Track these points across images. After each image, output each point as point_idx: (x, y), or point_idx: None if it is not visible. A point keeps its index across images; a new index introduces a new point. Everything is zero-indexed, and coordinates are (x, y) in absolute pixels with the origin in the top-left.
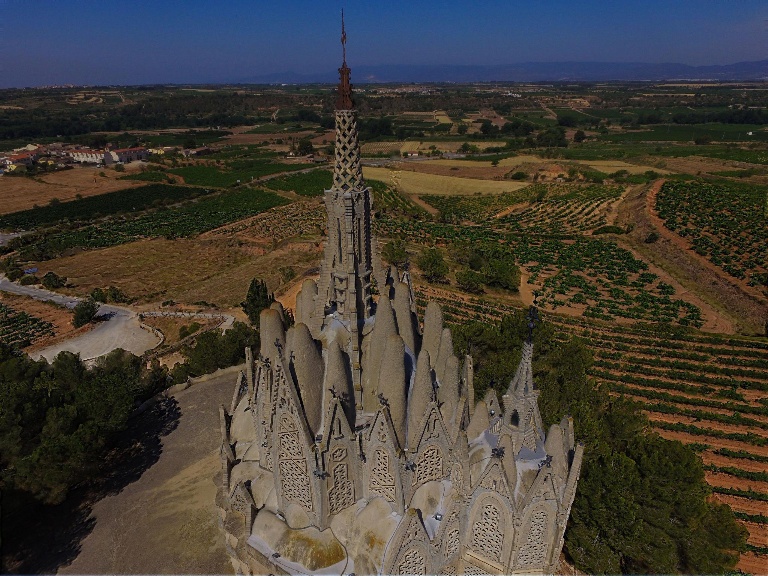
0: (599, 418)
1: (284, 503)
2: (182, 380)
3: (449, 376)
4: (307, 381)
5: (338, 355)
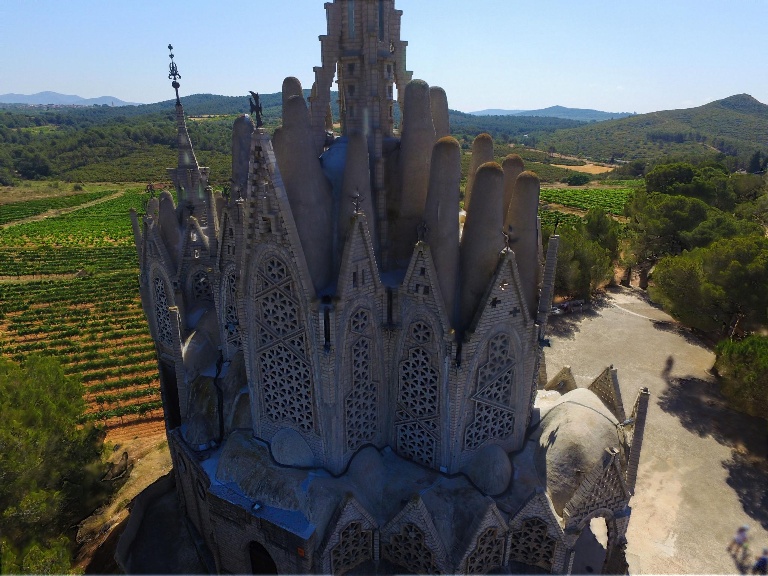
0: None
1: None
2: None
3: None
4: None
5: None
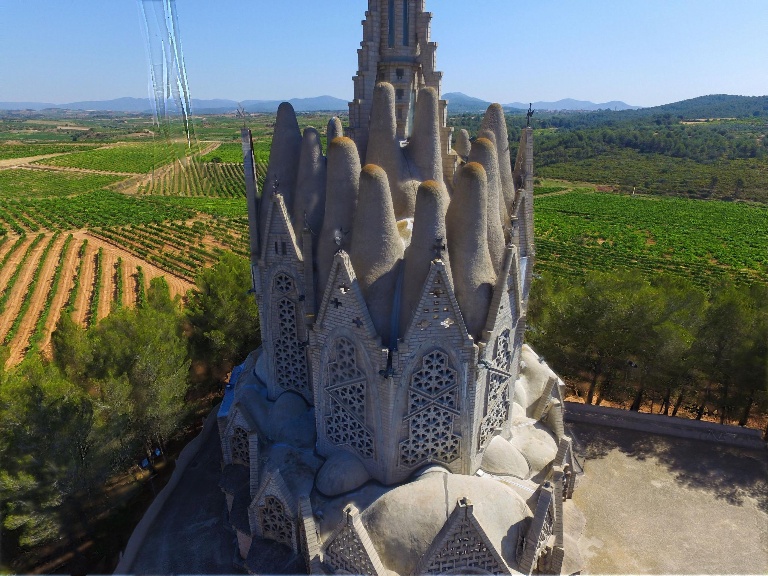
0: None
1: None
2: None
3: None
4: None
5: None
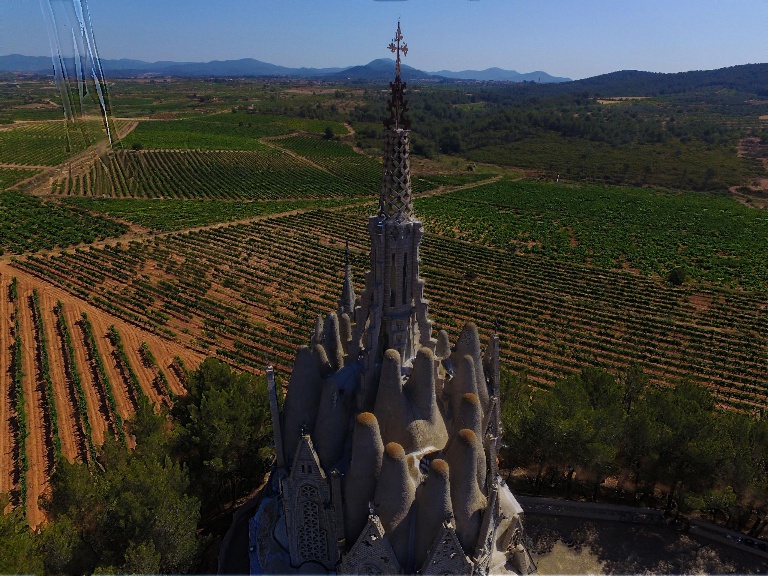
0: (129, 458)
1: None
2: None
3: None
4: None
5: None
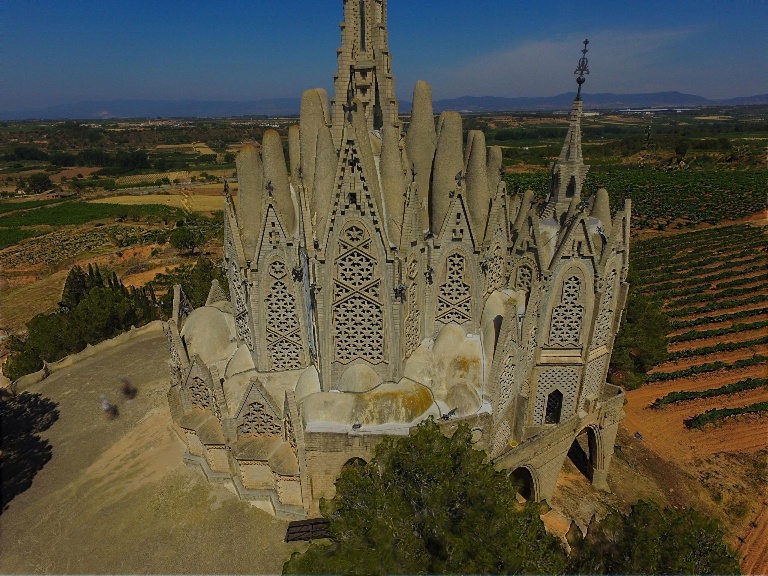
0: None
1: (335, 374)
2: (31, 371)
3: (495, 169)
4: (372, 173)
5: (397, 142)
